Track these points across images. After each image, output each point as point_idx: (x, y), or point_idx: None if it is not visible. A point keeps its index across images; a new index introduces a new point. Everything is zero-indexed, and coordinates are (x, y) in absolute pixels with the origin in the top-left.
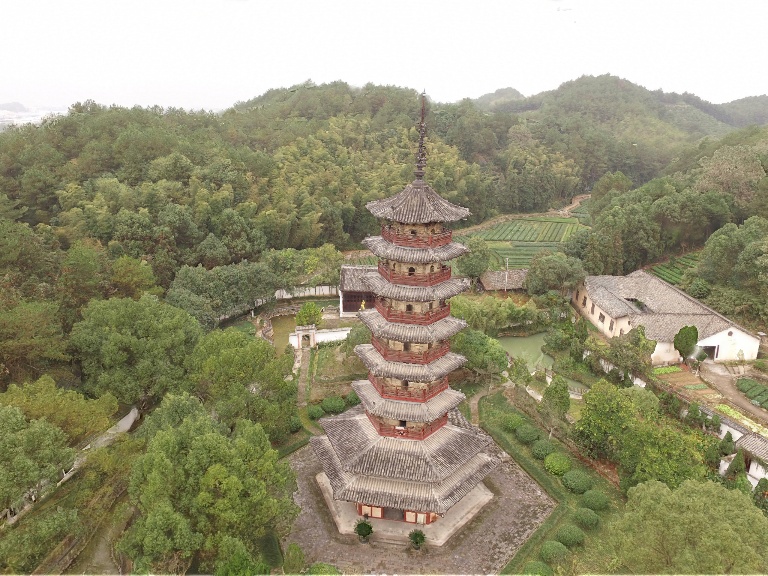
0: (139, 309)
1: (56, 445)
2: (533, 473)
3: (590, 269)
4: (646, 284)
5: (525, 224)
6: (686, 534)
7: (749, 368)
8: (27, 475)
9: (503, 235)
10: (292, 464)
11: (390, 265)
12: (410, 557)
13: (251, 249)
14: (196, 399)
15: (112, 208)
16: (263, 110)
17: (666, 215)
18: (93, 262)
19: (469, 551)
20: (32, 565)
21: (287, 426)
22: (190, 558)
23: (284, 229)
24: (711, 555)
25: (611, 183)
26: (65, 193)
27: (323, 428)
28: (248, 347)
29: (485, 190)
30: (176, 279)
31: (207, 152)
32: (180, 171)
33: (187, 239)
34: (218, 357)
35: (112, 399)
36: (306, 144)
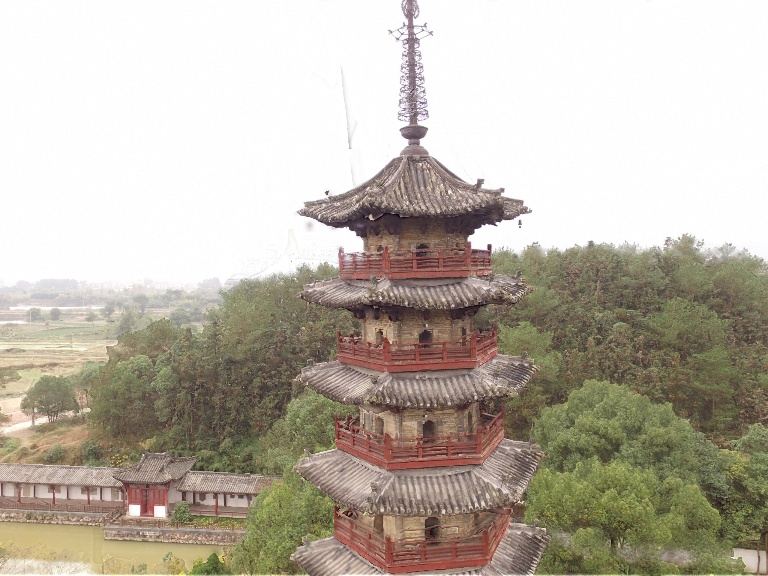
0: None
1: None
2: None
3: None
4: None
5: None
6: None
7: None
8: None
9: None
10: None
11: None
12: None
13: None
14: None
15: None
16: None
17: None
18: None
19: None
20: None
21: None
22: None
23: None
24: None
25: None
26: None
27: None
28: None
29: None
30: None
31: None
32: None
33: None
34: None
35: None
36: None
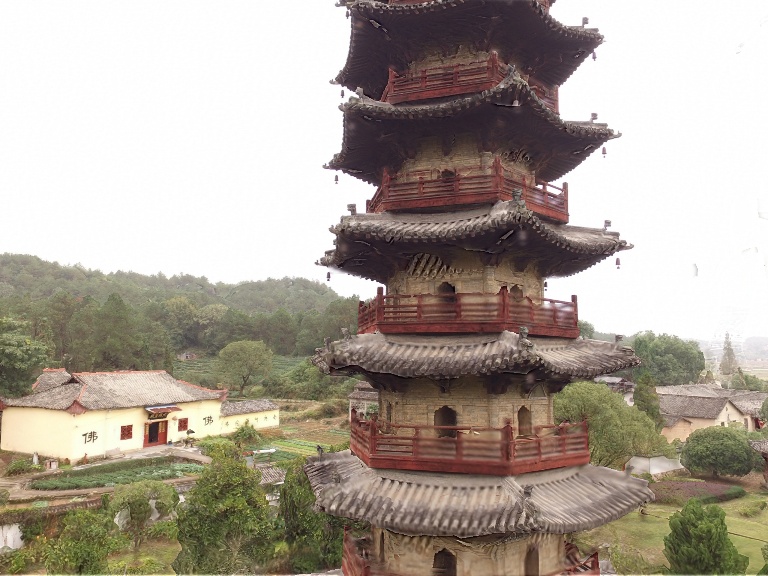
0: None
1: None
2: None
3: None
4: None
5: None
6: None
7: (4, 479)
8: None
9: None
10: None
11: None
12: None
13: None
14: None
15: None
16: None
17: None
18: None
19: None
20: None
21: None
22: None
23: None
24: None
25: None
26: None
27: None
28: None
29: None
30: None
31: None
32: None
33: None
34: None
35: None
36: None
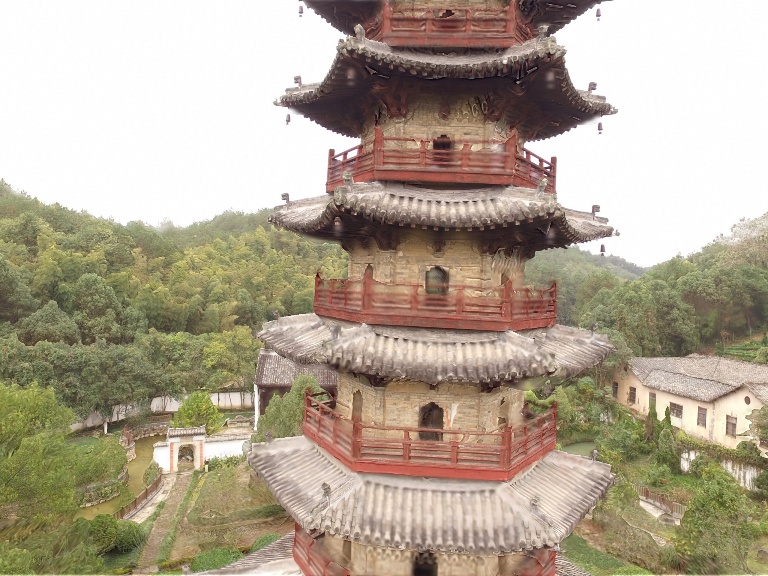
0: None
1: None
2: None
3: None
4: (715, 366)
5: None
6: None
7: None
8: None
9: None
10: None
11: None
12: None
13: (119, 333)
14: None
15: None
16: (179, 229)
17: (698, 292)
18: None
19: None
20: None
21: None
22: None
23: (178, 315)
24: None
25: (599, 282)
26: None
27: None
28: None
29: None
30: None
31: (80, 222)
32: (31, 235)
33: (10, 310)
34: None
35: None
36: (225, 245)
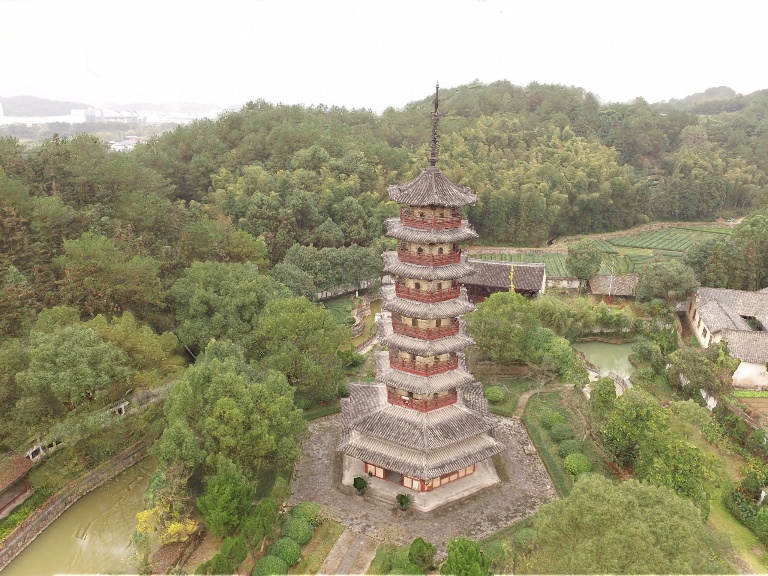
0: (225, 272)
1: (116, 363)
2: (550, 469)
3: (710, 281)
4: None
5: (681, 233)
6: (598, 525)
7: None
8: (86, 380)
9: (648, 242)
10: (331, 422)
11: (407, 245)
12: (394, 515)
13: (365, 235)
14: (237, 347)
15: (251, 191)
16: (423, 109)
17: None
18: (220, 234)
19: (450, 522)
20: (105, 458)
21: (332, 388)
22: (193, 468)
23: None
24: (609, 547)
25: None
26: (218, 177)
27: (349, 391)
28: (303, 313)
29: (637, 194)
30: (287, 255)
31: (345, 145)
32: (317, 162)
33: (309, 222)
34: (276, 318)
35: (173, 337)
36: (449, 141)
